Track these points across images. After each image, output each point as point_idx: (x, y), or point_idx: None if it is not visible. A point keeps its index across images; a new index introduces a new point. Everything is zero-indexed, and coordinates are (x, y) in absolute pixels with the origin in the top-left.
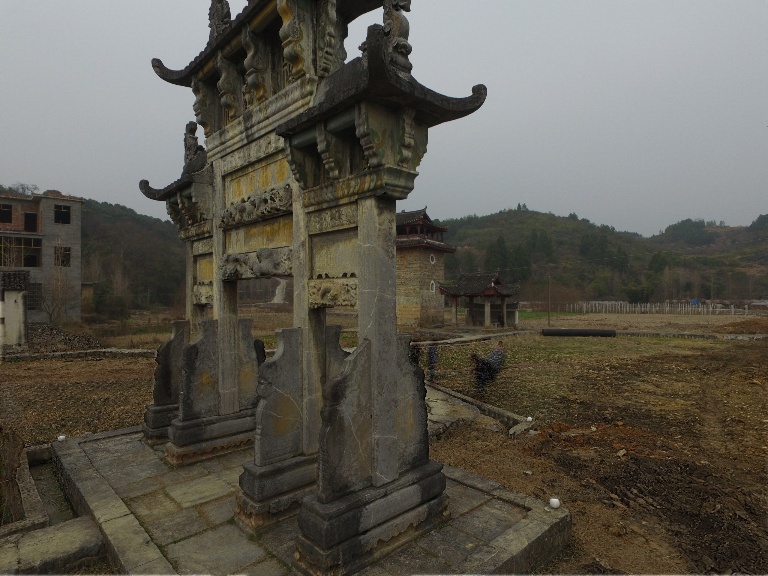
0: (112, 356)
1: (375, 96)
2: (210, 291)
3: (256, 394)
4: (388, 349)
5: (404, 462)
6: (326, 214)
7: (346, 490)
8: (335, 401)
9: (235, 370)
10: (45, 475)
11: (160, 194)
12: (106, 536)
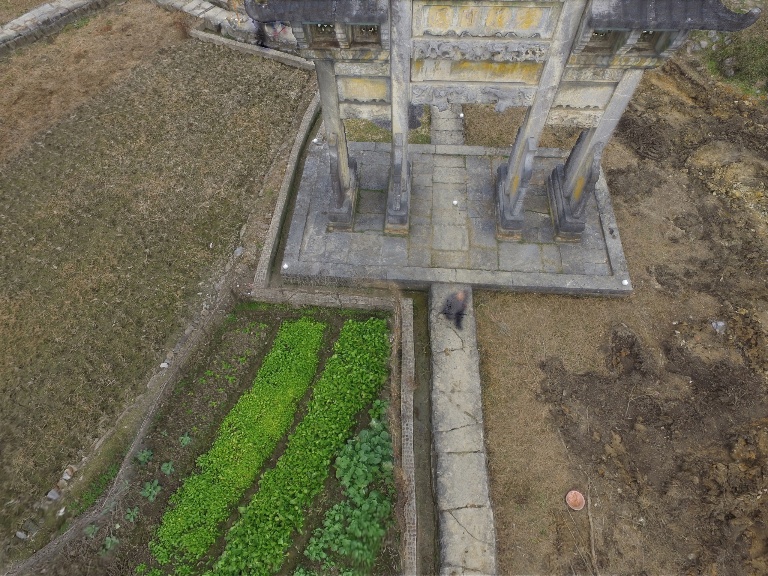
0: None
1: None
2: (384, 111)
3: None
4: None
5: None
6: (589, 70)
7: None
8: None
9: None
10: None
11: (292, 19)
12: (471, 283)
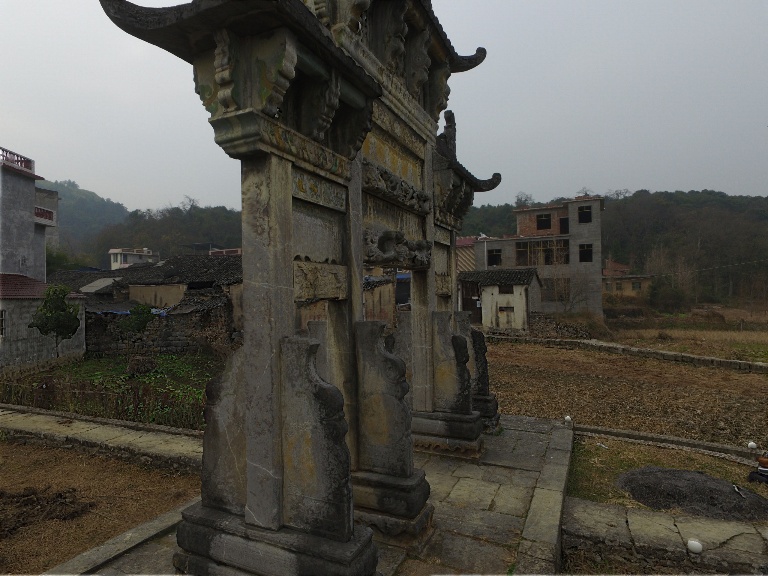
0: (584, 347)
1: (188, 47)
2: None
3: (455, 398)
4: (258, 353)
5: (300, 516)
6: None
7: (222, 504)
8: (210, 400)
9: (427, 366)
10: None
11: None
12: None
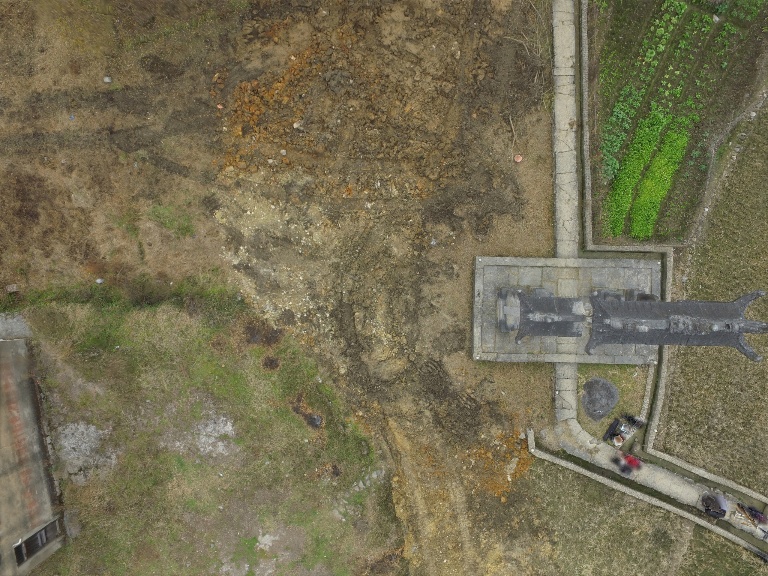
0: None
1: None
2: None
3: None
4: None
5: None
6: None
7: None
8: None
9: None
10: (648, 258)
11: None
12: (558, 258)
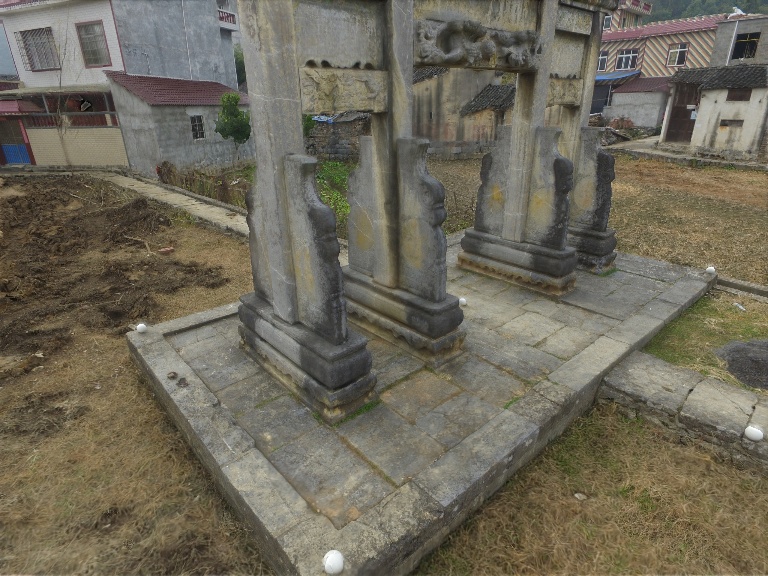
0: None
1: None
2: None
3: (548, 230)
4: (265, 168)
5: (308, 317)
6: None
7: (265, 297)
8: None
9: (521, 192)
10: None
11: None
12: None
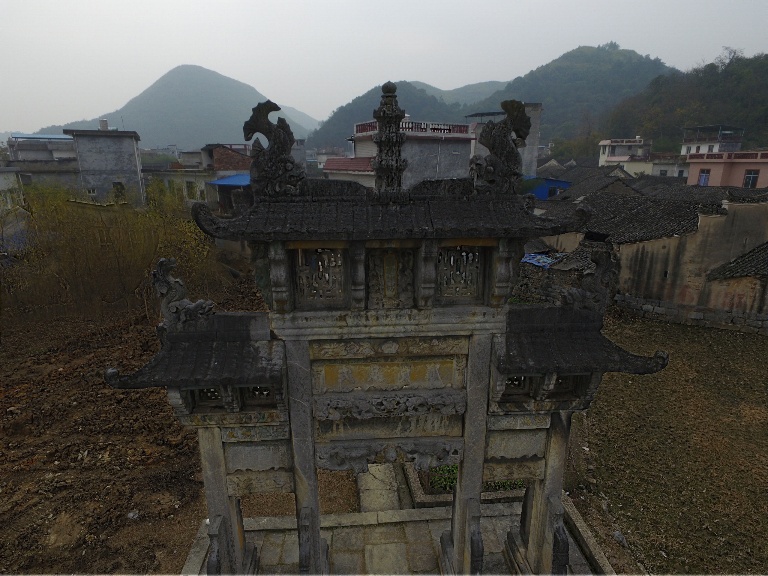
0: None
1: None
2: None
3: None
4: None
5: None
6: None
7: None
8: None
9: None
10: None
11: None
12: None
